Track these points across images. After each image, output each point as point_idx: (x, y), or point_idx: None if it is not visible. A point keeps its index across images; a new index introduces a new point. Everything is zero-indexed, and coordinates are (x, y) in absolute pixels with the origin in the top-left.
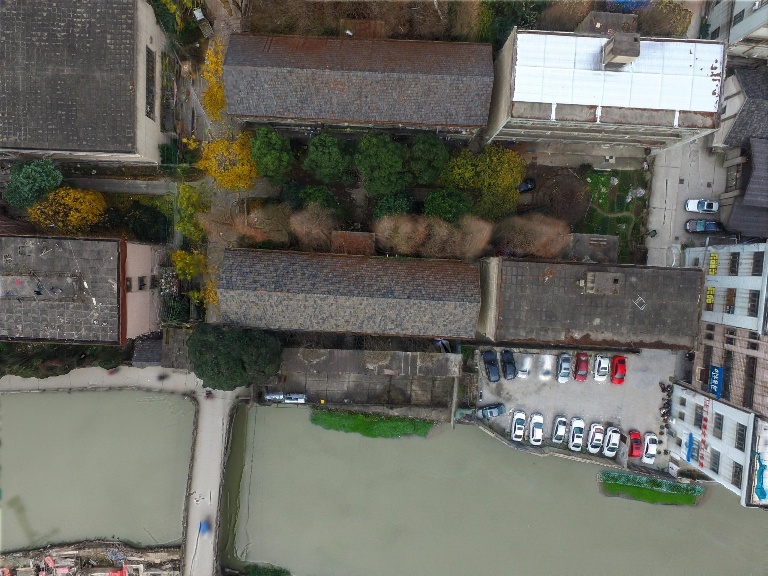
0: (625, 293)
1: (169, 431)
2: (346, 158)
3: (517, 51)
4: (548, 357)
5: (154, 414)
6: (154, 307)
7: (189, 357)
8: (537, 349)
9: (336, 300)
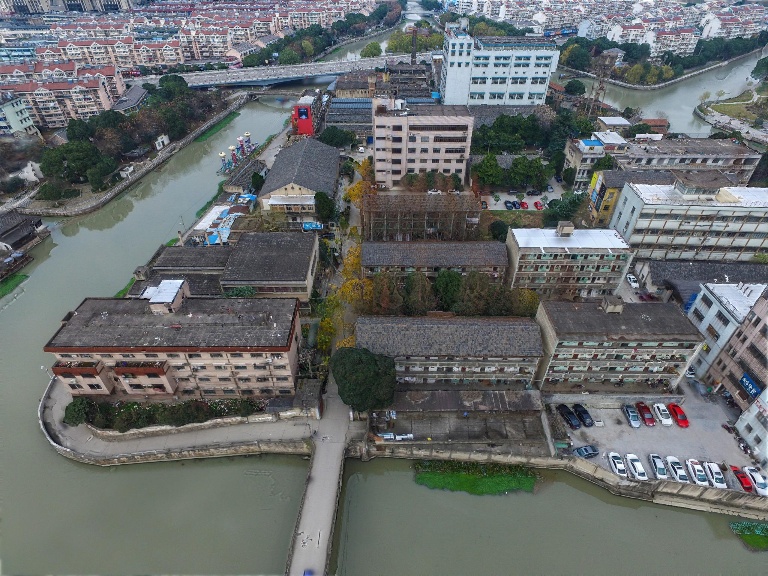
0: (632, 313)
1: (264, 516)
2: (429, 284)
3: (514, 233)
4: (614, 410)
5: (256, 490)
6: (296, 363)
7: (333, 363)
8: (600, 400)
9: (439, 329)
